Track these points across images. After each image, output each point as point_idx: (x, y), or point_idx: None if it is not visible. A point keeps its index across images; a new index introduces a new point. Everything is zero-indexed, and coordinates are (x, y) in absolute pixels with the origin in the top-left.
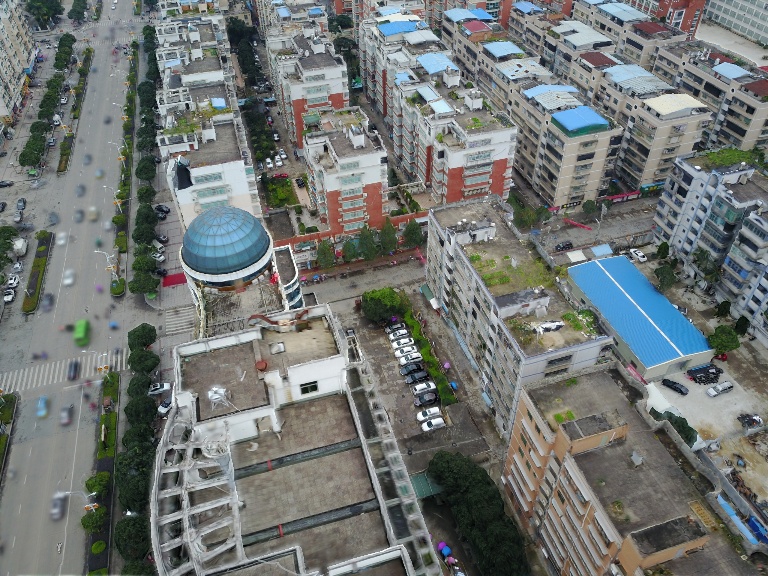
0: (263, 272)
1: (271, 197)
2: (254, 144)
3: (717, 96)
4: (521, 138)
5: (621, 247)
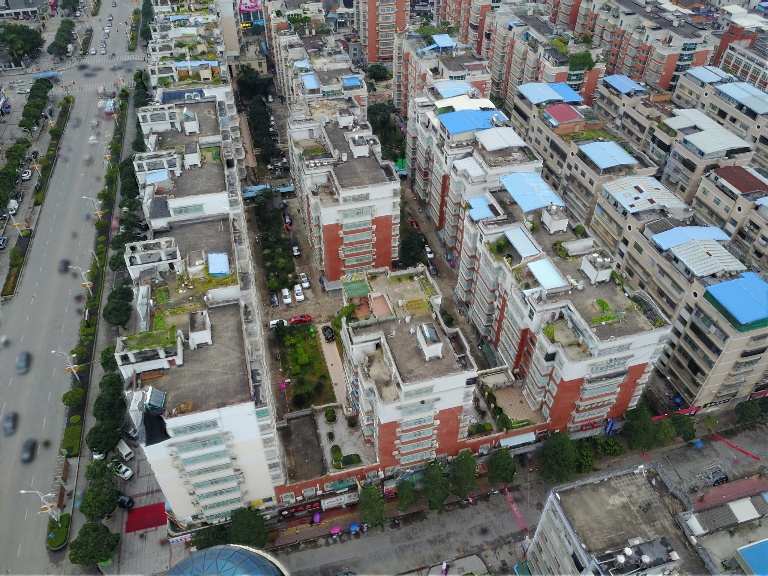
0: None
1: (288, 358)
2: (266, 262)
3: None
4: None
5: None
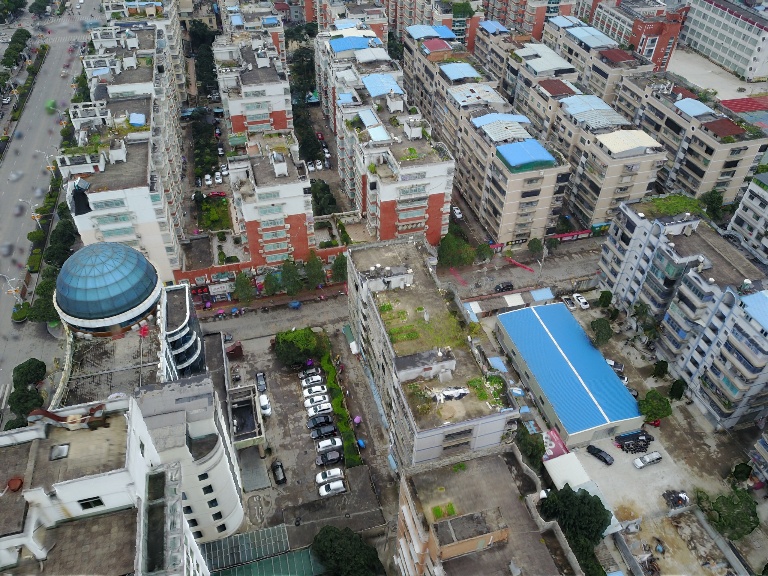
0: (146, 317)
1: (203, 217)
2: (196, 158)
3: (677, 133)
4: (469, 168)
5: (564, 291)
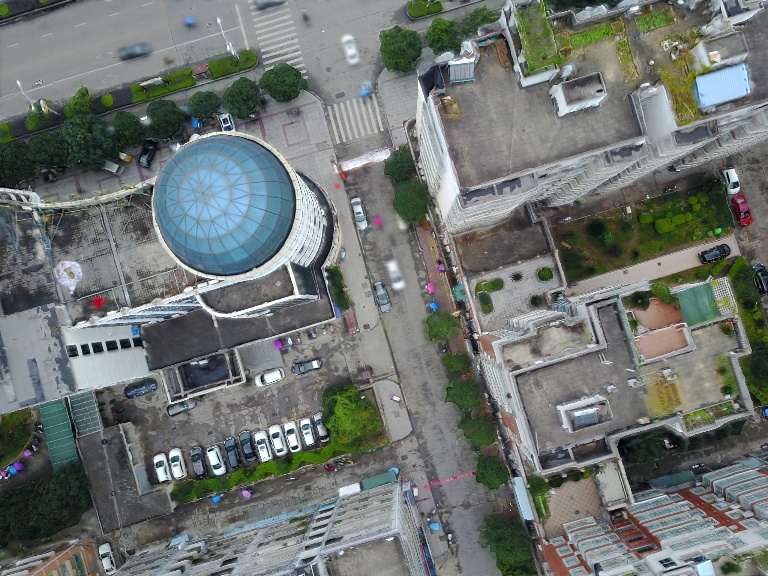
0: None
1: (668, 205)
2: None
3: None
4: None
5: None
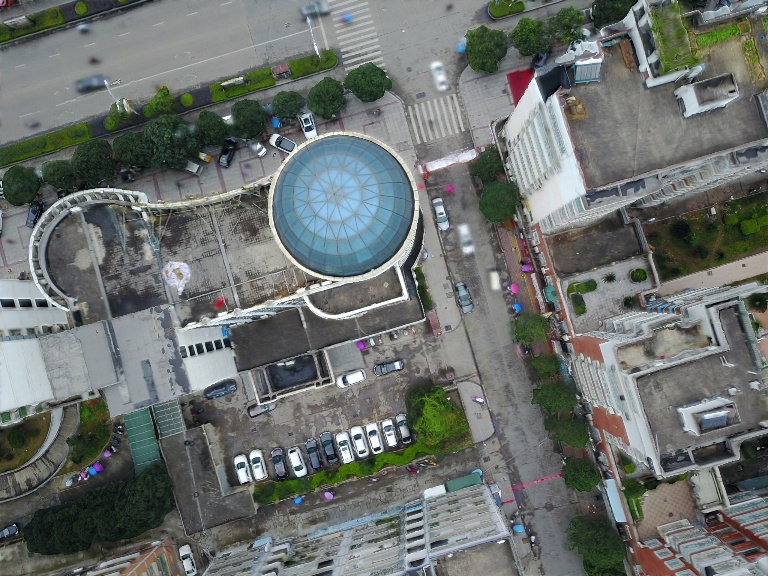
0: None
1: (752, 206)
2: None
3: None
4: None
5: None
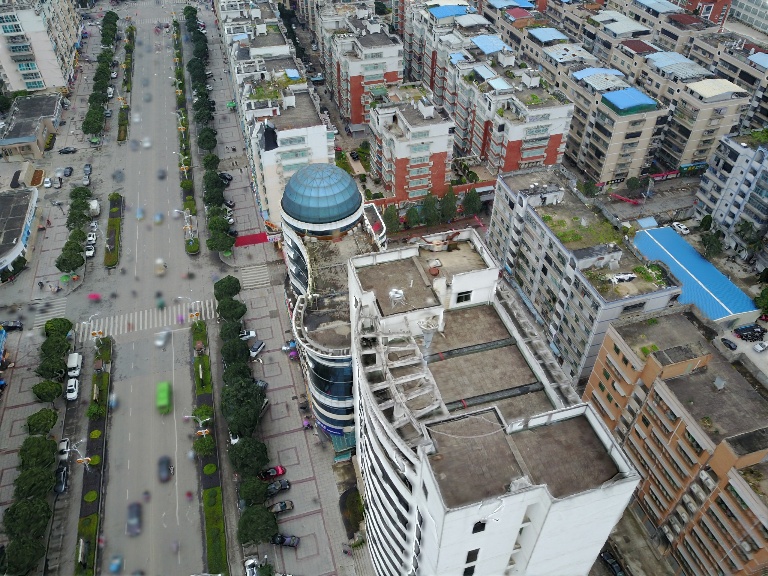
0: (357, 224)
1: None
2: None
3: (752, 84)
4: None
5: (664, 221)
